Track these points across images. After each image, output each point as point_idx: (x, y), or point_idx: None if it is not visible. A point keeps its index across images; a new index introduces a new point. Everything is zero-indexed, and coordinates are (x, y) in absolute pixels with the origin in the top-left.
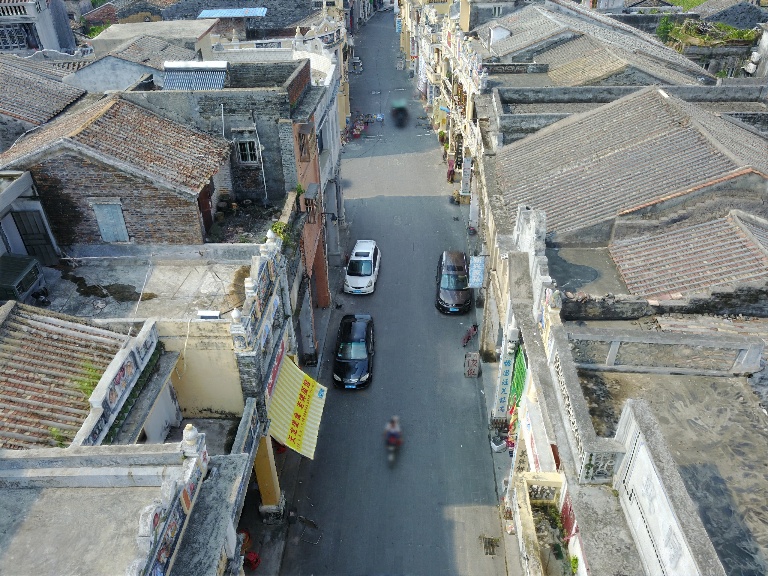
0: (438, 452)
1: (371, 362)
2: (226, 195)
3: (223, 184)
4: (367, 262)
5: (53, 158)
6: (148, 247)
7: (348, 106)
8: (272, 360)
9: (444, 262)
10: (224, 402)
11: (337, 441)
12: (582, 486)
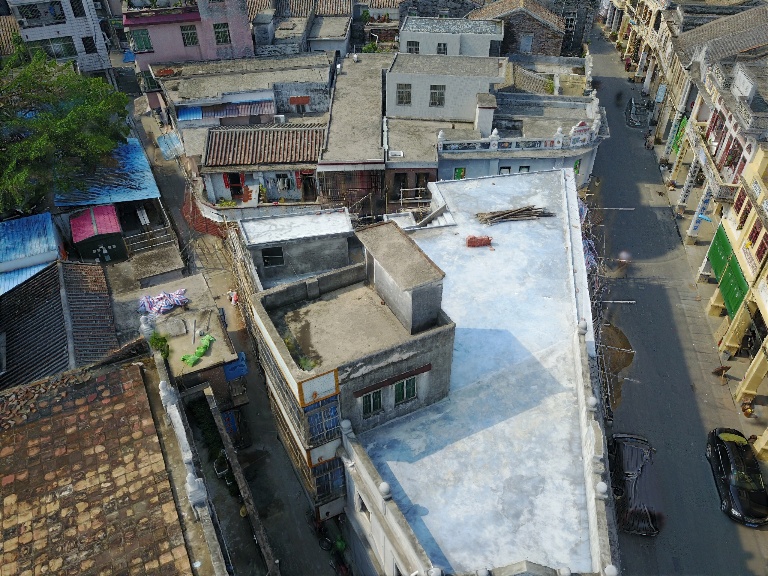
0: (635, 169)
1: None
2: None
3: None
4: None
5: (515, 15)
6: (536, 56)
7: None
8: None
9: (633, 101)
10: None
11: None
12: (721, 90)
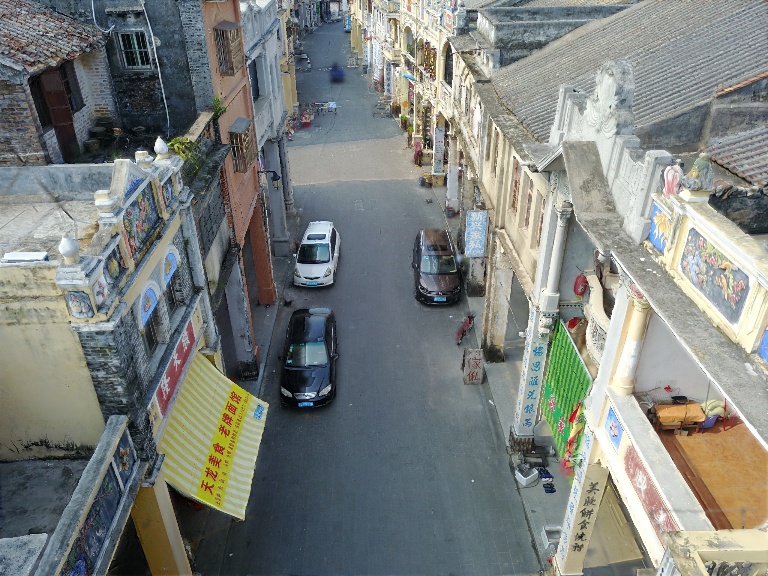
0: (439, 492)
1: (334, 369)
2: (105, 118)
3: (99, 100)
4: (323, 246)
5: None
6: None
7: (295, 93)
8: (167, 353)
9: (423, 241)
10: (69, 427)
11: (288, 485)
12: None
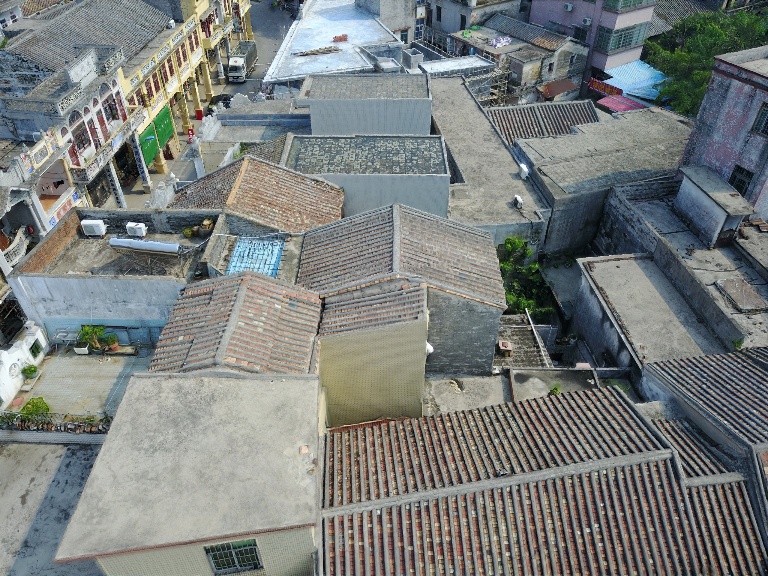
0: None
1: None
2: None
3: None
4: None
5: None
6: None
7: None
8: None
9: None
10: None
11: None
12: None
